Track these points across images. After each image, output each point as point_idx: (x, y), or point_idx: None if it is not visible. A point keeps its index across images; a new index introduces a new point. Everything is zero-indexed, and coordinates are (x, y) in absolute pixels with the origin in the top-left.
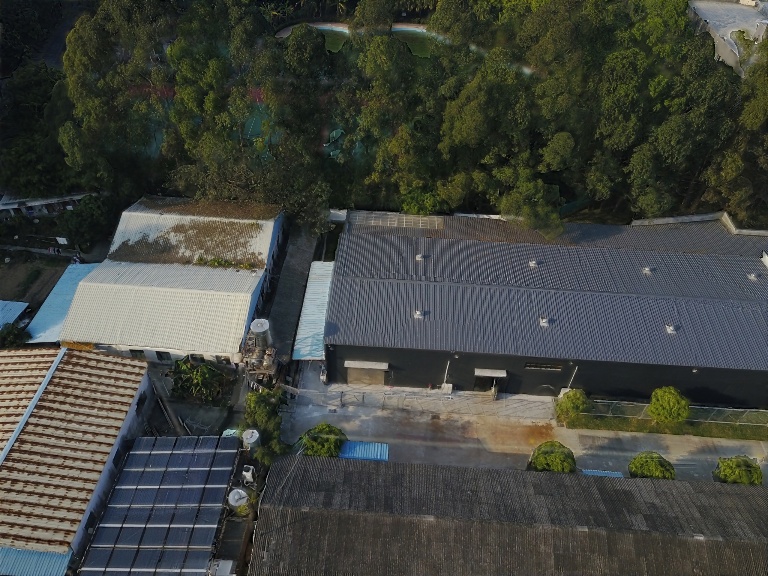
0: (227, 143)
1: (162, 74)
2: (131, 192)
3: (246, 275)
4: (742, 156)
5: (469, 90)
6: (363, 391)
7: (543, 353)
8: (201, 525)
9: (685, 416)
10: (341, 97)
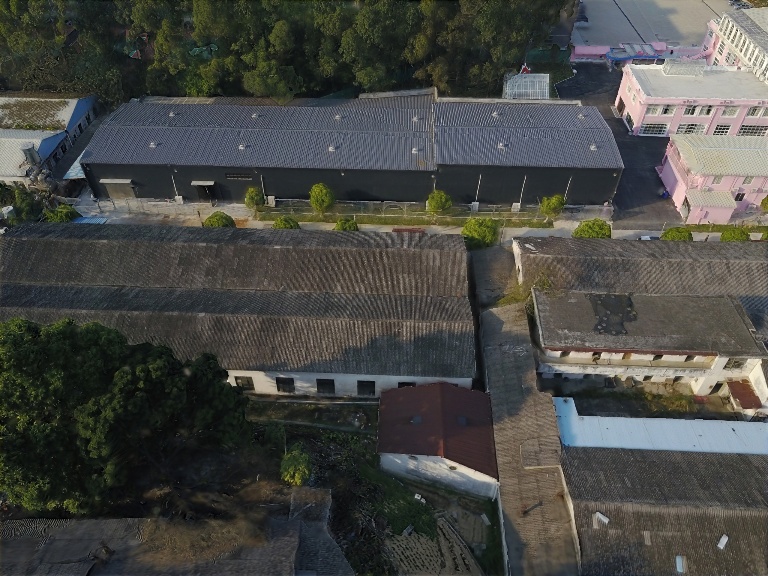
0: (38, 40)
1: None
2: None
3: (47, 132)
4: (430, 38)
5: None
6: (120, 204)
7: (232, 164)
8: None
9: (327, 201)
10: (115, 0)
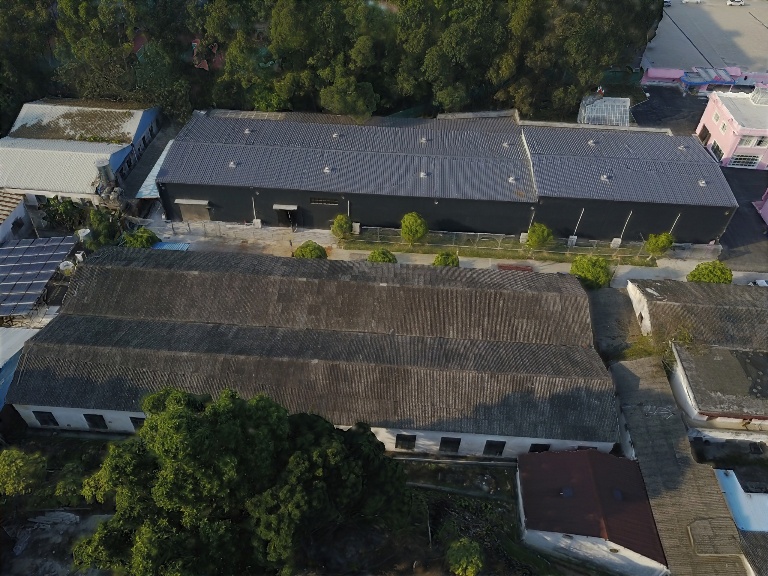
0: (104, 47)
1: None
2: (34, 91)
3: (113, 146)
4: (517, 58)
5: None
6: (194, 226)
7: (319, 188)
8: (37, 281)
9: (422, 232)
10: (189, 8)
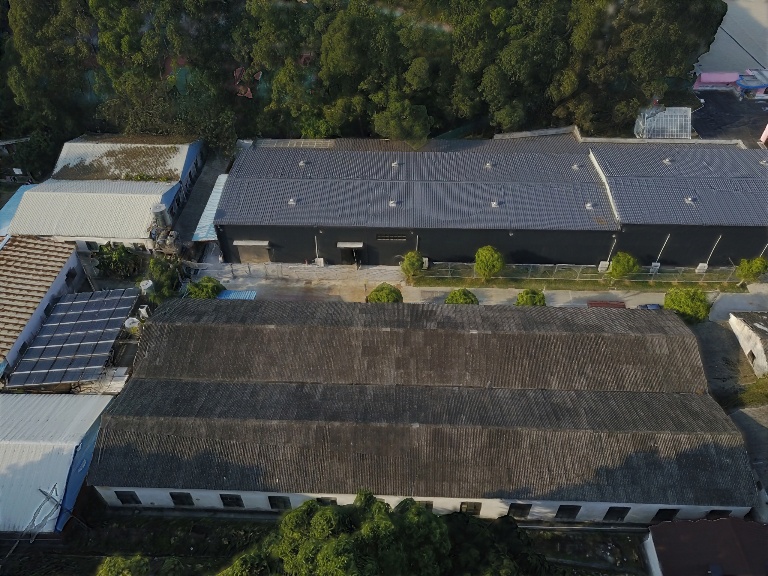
0: (146, 81)
1: (86, 23)
2: (73, 129)
3: (162, 184)
4: (578, 73)
5: (335, 24)
6: (253, 267)
7: (387, 224)
8: (103, 341)
9: (499, 267)
10: (235, 37)
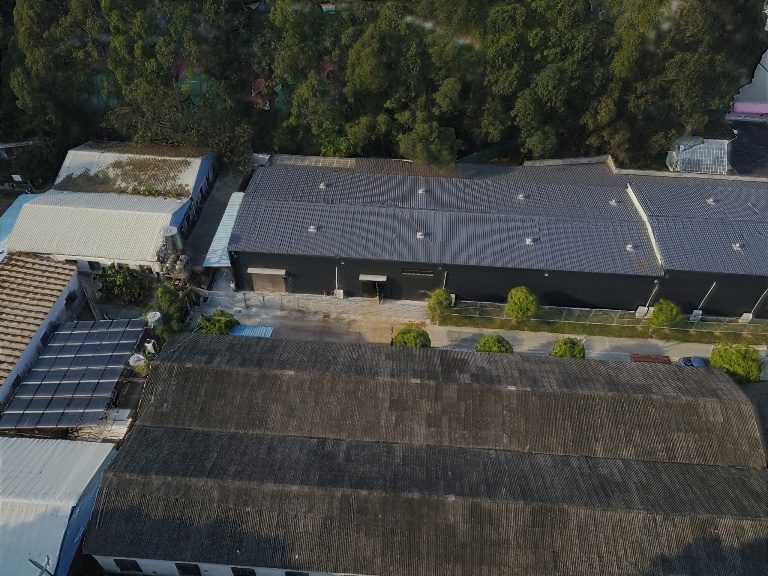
0: (159, 89)
1: (98, 25)
2: (78, 135)
3: (172, 201)
4: (616, 102)
5: (364, 38)
6: (267, 297)
7: (415, 258)
8: (105, 380)
9: (533, 310)
10: (256, 47)
